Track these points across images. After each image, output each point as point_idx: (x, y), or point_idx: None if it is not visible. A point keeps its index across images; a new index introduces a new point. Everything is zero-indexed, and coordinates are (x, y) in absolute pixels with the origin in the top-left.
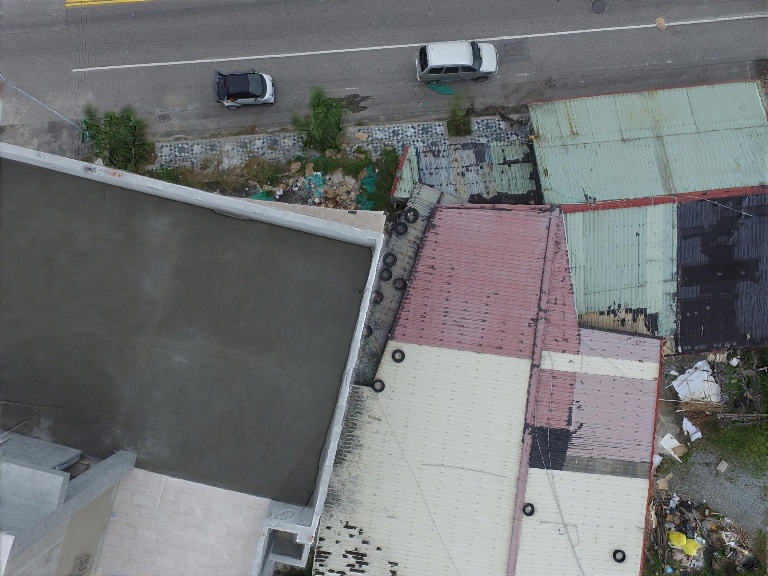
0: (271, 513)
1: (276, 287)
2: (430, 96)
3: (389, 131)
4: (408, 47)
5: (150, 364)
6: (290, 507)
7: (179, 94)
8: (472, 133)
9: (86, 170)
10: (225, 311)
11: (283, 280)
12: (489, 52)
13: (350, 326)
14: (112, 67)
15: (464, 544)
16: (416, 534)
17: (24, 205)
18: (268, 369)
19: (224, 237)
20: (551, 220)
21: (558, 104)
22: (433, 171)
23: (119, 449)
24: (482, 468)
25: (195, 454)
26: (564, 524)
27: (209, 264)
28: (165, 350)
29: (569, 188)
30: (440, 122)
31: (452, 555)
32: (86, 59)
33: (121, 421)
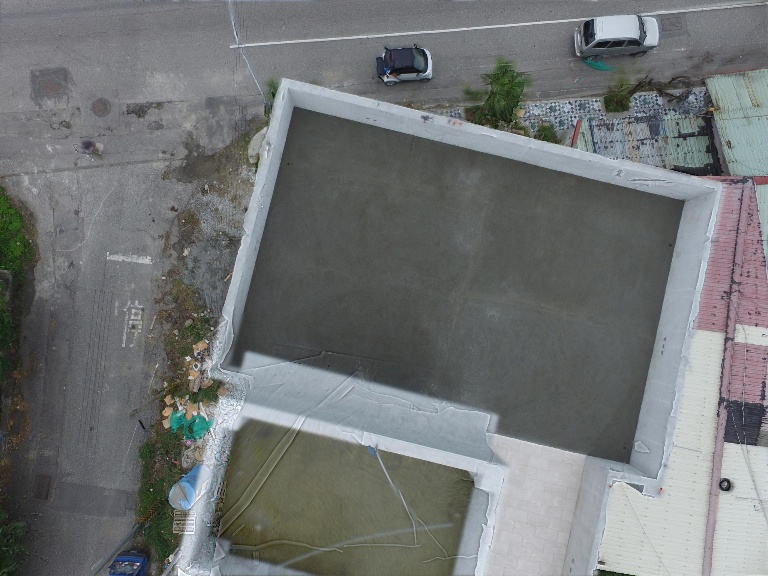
0: (603, 466)
1: (585, 240)
2: (586, 72)
3: (546, 107)
4: (564, 22)
5: (462, 317)
6: (609, 462)
7: (335, 70)
8: (630, 109)
9: (419, 118)
10: (536, 264)
11: (592, 233)
12: (651, 26)
13: (662, 280)
14: (269, 43)
15: (659, 519)
16: (608, 509)
17: (329, 158)
18: (579, 323)
19: (531, 190)
20: (744, 191)
21: (735, 76)
22: (608, 144)
23: (442, 401)
24: (676, 442)
25: (508, 409)
26: (759, 500)
27: (517, 217)
28: (476, 303)
29: (754, 160)
30: (597, 98)
31: (647, 530)
32: (244, 35)
33: (434, 375)
